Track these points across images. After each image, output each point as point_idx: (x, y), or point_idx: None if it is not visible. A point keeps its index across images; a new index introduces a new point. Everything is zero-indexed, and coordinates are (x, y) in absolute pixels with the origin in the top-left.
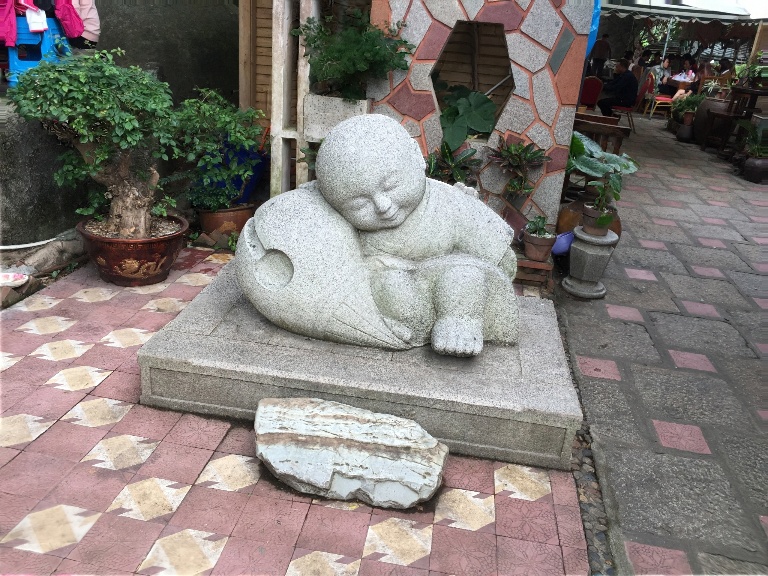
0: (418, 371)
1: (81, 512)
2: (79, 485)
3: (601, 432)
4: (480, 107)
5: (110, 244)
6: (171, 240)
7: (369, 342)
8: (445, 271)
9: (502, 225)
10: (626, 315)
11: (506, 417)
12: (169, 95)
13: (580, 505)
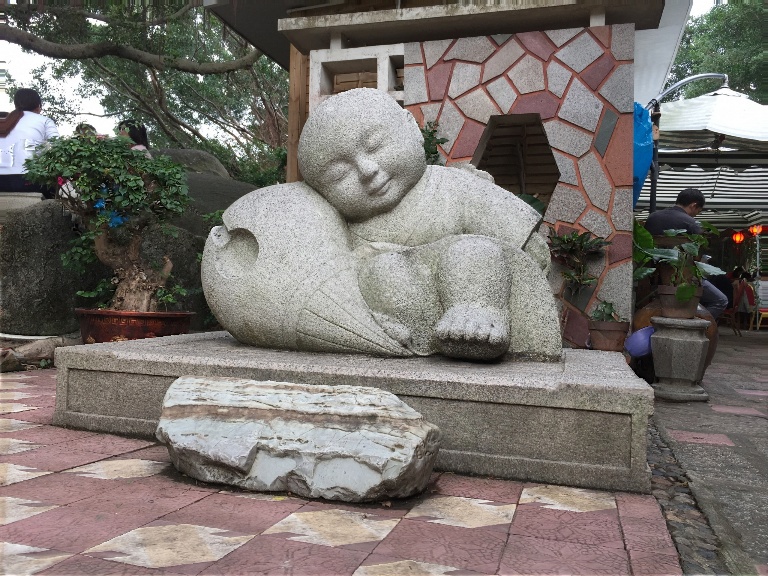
0: (413, 365)
1: None
2: None
3: (705, 475)
4: None
5: (101, 318)
6: (171, 321)
7: (353, 343)
8: (449, 246)
9: (524, 204)
10: (738, 410)
11: (535, 402)
12: (186, 174)
13: (667, 521)
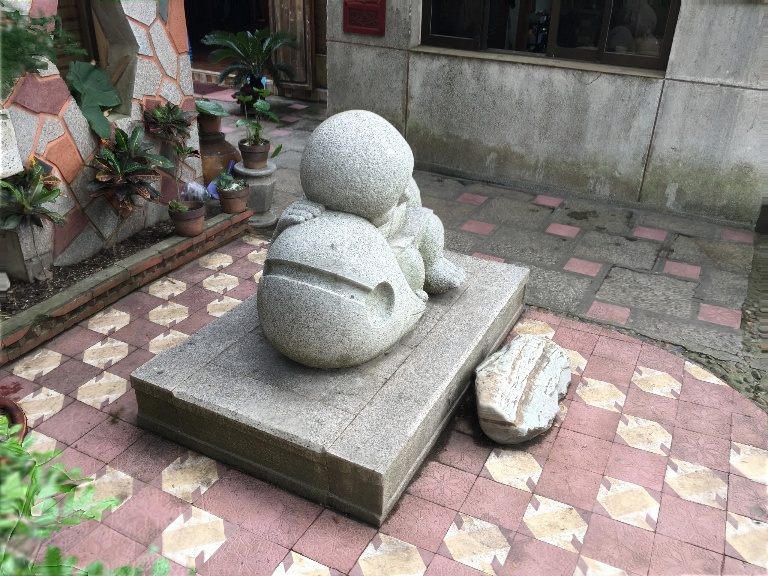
0: (459, 312)
1: (581, 571)
2: (538, 574)
3: None
4: (88, 78)
5: None
6: None
7: None
8: (428, 227)
9: None
10: None
11: None
12: None
13: None
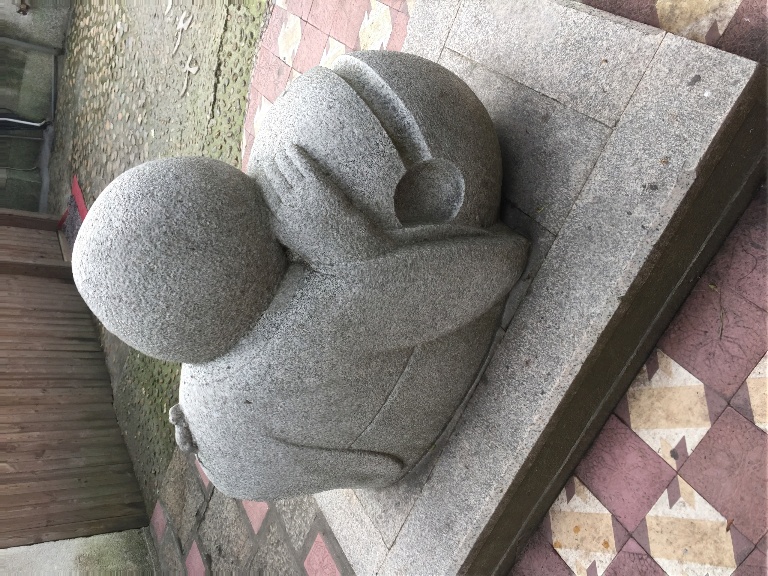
0: None
1: None
2: None
3: None
4: None
5: None
6: None
7: None
8: None
9: None
10: None
11: None
12: None
13: None
